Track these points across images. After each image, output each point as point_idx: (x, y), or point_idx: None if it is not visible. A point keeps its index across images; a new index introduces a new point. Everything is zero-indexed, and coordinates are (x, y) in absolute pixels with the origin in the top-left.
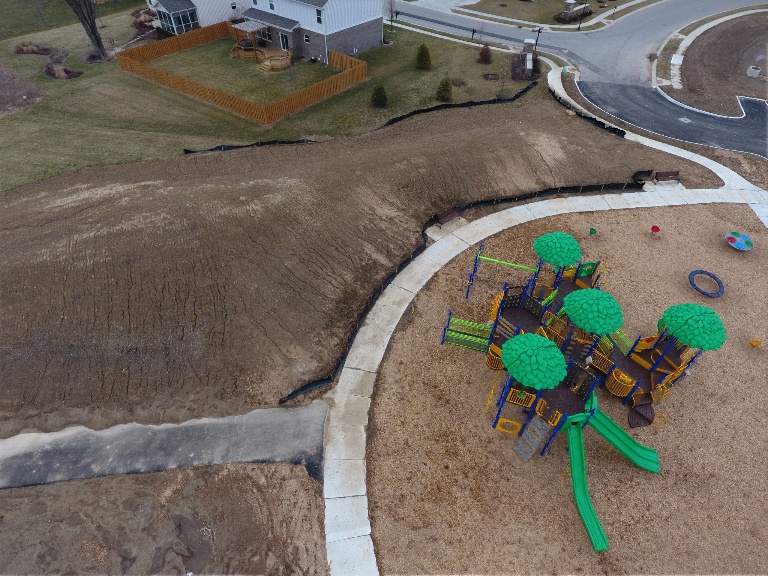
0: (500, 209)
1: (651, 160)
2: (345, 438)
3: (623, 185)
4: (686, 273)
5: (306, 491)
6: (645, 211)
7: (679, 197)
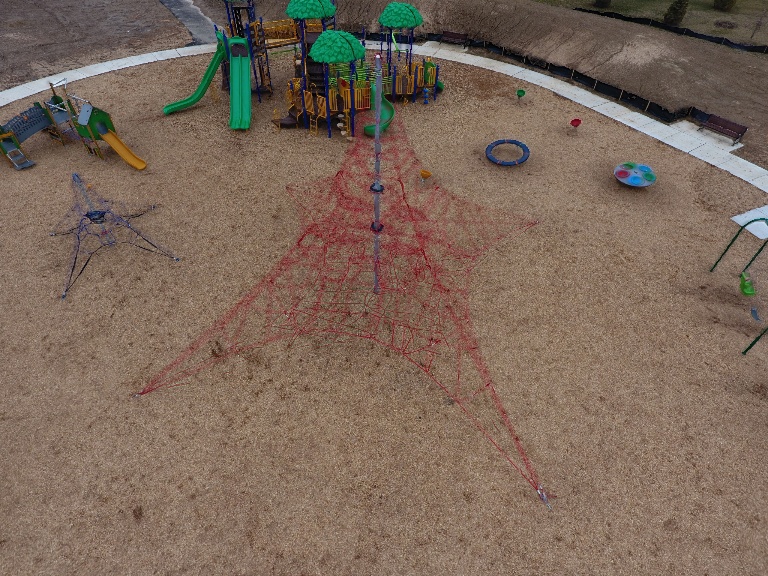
0: (502, 60)
1: (761, 124)
2: (215, 47)
3: (647, 103)
4: (520, 149)
5: (178, 44)
6: (619, 126)
7: (694, 146)
